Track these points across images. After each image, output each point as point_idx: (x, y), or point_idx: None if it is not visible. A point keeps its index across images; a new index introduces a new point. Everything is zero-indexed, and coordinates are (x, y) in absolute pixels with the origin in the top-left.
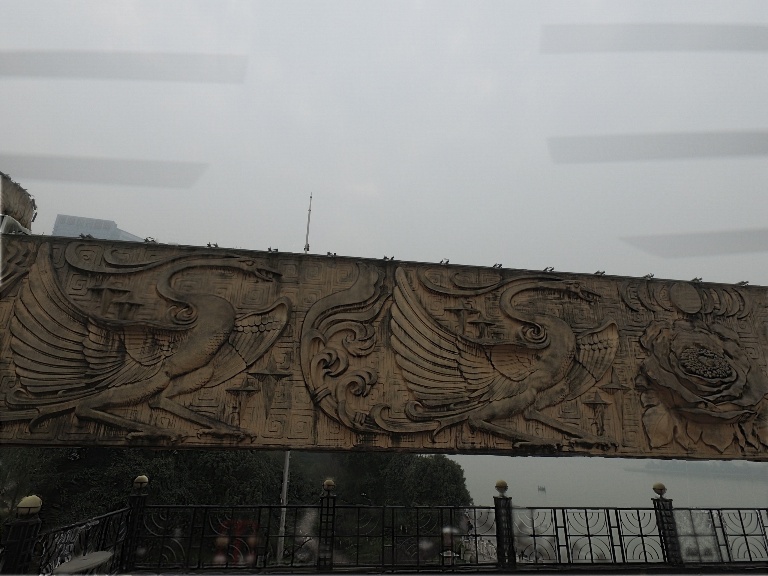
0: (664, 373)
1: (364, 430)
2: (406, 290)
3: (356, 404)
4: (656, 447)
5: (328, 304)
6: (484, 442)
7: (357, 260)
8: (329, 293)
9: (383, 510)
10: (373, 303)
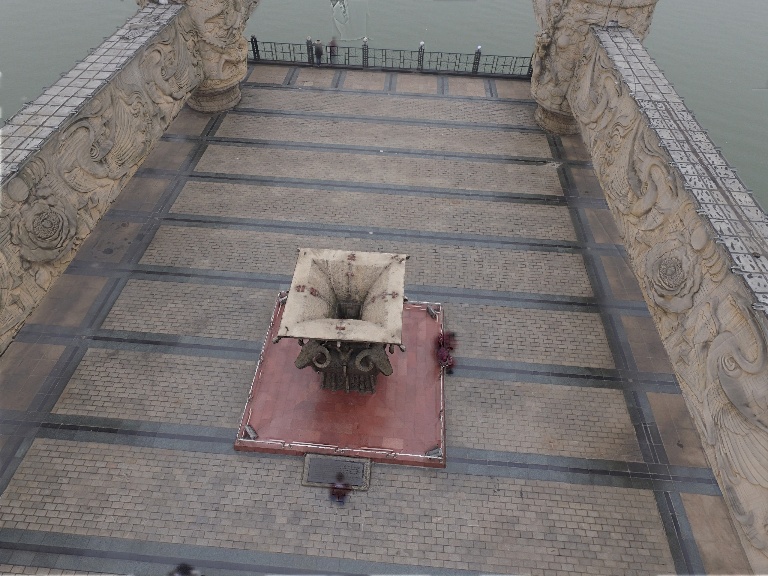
0: (35, 252)
1: None
2: None
3: None
4: (47, 288)
5: None
6: None
7: None
8: None
9: None
10: None
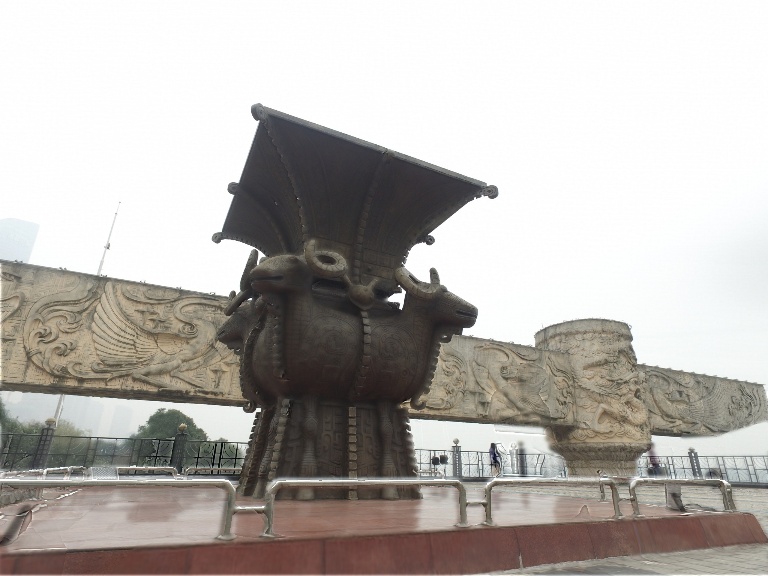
0: None
1: (59, 375)
2: (110, 296)
3: (58, 360)
4: None
5: (51, 299)
6: (140, 387)
7: (80, 274)
8: (54, 293)
9: (90, 439)
10: (85, 302)
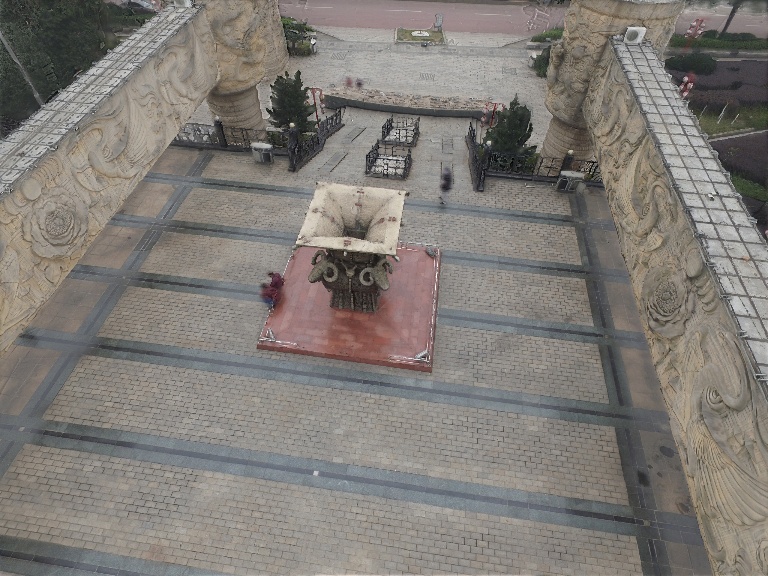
0: None
1: None
2: None
3: None
4: None
5: None
6: None
7: None
8: None
9: None
10: None
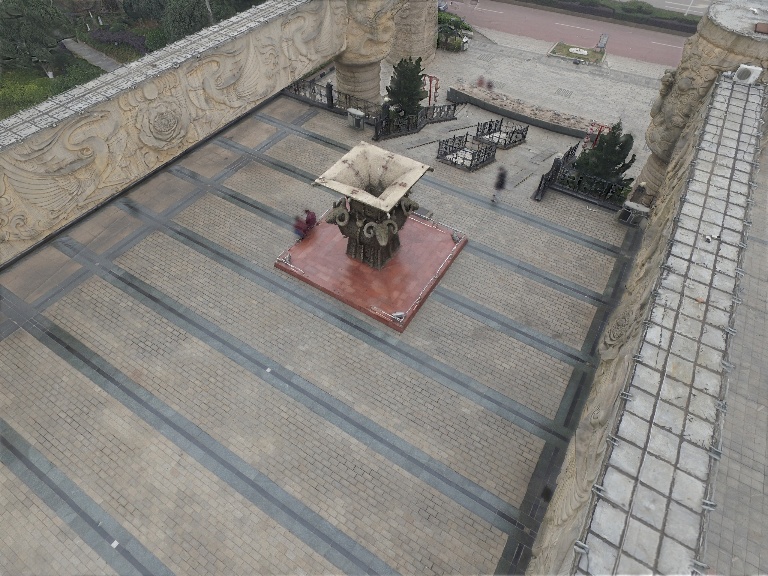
0: None
1: None
2: None
3: None
4: None
5: None
6: None
7: None
8: None
9: None
10: None
